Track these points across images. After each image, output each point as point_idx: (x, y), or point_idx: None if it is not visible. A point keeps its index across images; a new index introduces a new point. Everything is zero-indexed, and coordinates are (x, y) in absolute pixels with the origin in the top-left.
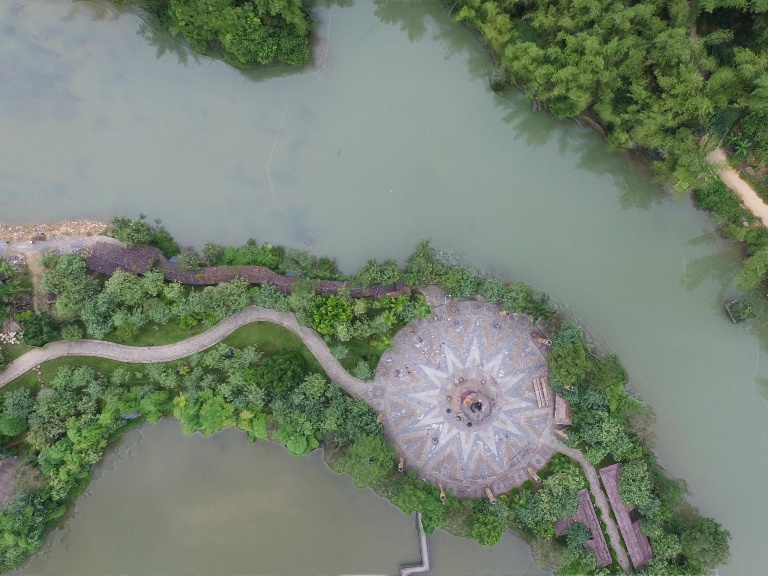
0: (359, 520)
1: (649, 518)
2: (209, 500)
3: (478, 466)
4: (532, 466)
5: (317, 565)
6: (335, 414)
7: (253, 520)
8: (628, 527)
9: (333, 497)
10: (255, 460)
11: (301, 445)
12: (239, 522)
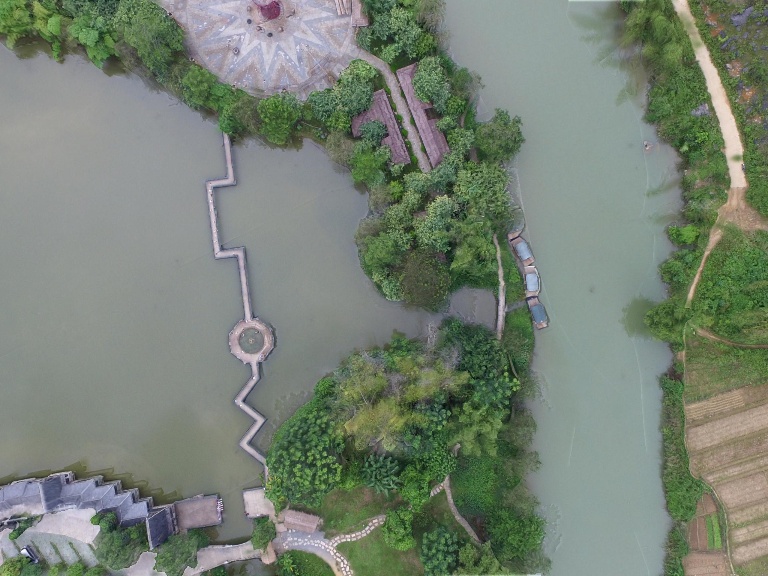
0: (165, 137)
1: (444, 113)
2: (17, 120)
3: (280, 76)
4: (333, 76)
5: (123, 180)
6: (125, 4)
7: (61, 139)
8: (424, 124)
9: (139, 114)
10: (62, 79)
11: (92, 36)
12: (47, 141)
